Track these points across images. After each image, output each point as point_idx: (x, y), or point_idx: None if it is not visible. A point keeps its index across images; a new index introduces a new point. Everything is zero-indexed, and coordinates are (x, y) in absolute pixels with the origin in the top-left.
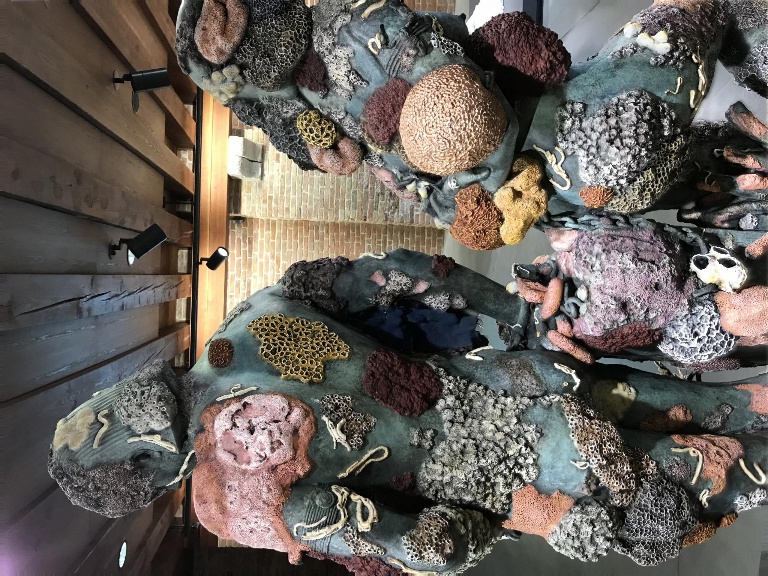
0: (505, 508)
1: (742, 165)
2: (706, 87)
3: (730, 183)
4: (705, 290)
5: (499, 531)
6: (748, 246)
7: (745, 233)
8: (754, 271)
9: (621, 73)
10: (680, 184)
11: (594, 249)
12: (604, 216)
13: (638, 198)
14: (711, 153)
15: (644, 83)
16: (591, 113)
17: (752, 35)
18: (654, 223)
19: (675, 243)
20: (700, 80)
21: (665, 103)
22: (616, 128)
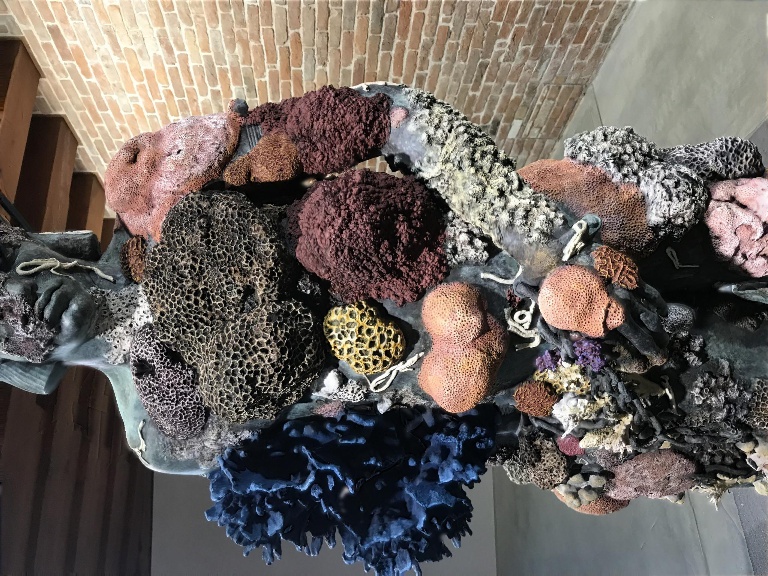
0: None
1: None
2: None
3: None
4: None
5: None
6: None
7: None
8: None
9: None
10: None
11: None
12: None
13: None
14: None
15: None
16: None
17: None
18: None
19: None
20: None
21: None
22: None
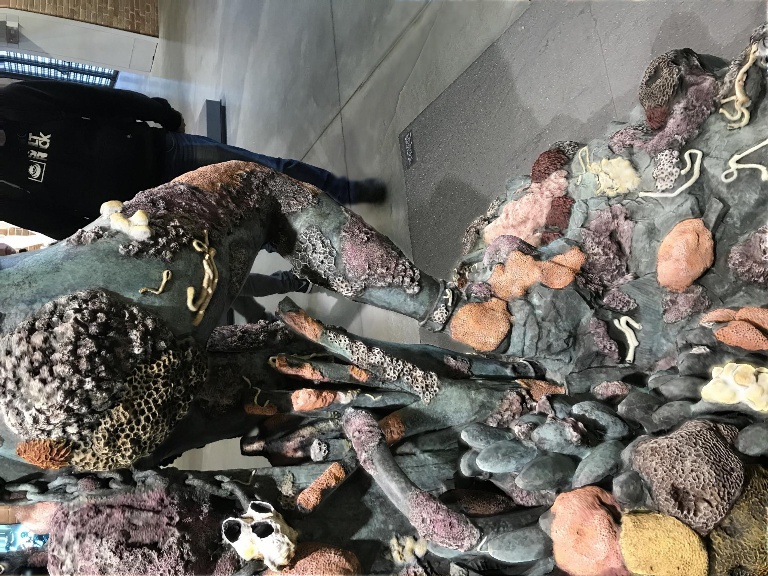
0: None
1: (302, 376)
2: (228, 282)
3: (289, 401)
4: (244, 572)
5: None
6: (300, 494)
7: (310, 468)
8: (322, 523)
9: (69, 266)
10: (226, 407)
11: (64, 535)
12: (87, 476)
13: (109, 451)
14: (266, 362)
15: (104, 280)
16: (11, 327)
17: (296, 220)
18: (166, 477)
19: (203, 502)
20: (206, 273)
21: (136, 307)
22: (44, 349)
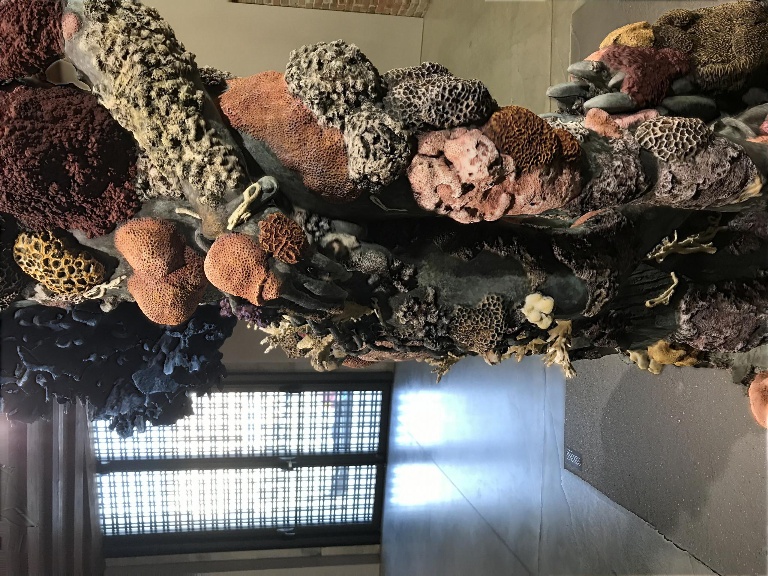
0: (216, 79)
1: None
2: None
3: None
4: None
5: (221, 122)
6: None
7: None
8: None
9: None
10: None
11: None
12: None
13: None
14: None
15: None
16: None
17: None
18: None
19: None
20: None
21: None
22: None
